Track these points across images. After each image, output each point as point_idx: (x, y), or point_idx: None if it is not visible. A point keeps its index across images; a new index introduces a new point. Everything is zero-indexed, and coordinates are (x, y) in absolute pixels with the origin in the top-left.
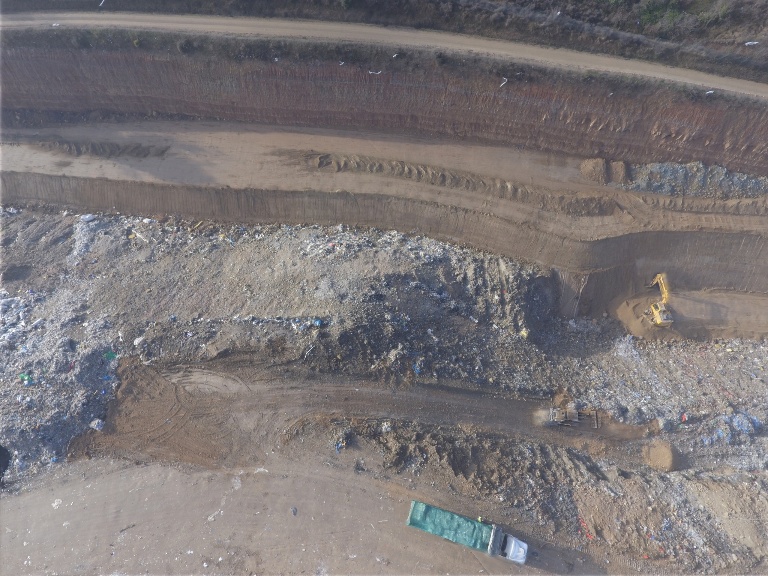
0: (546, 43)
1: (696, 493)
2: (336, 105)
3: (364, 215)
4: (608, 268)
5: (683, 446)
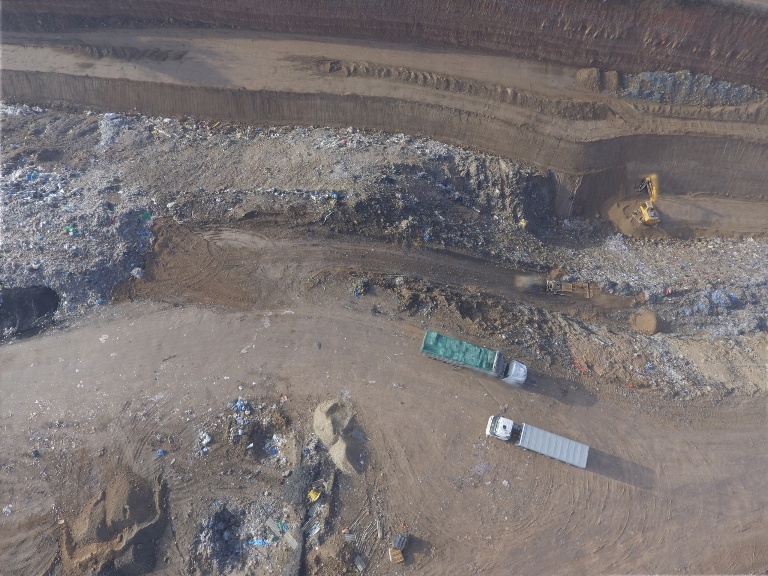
0: None
1: (677, 347)
2: (346, 12)
3: (373, 118)
4: (601, 170)
5: (666, 315)
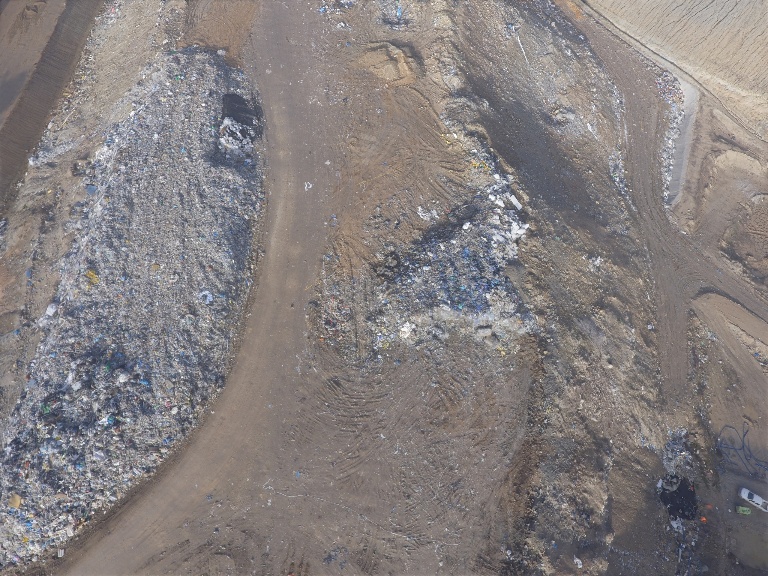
0: None
1: None
2: None
3: (91, 3)
4: None
5: None
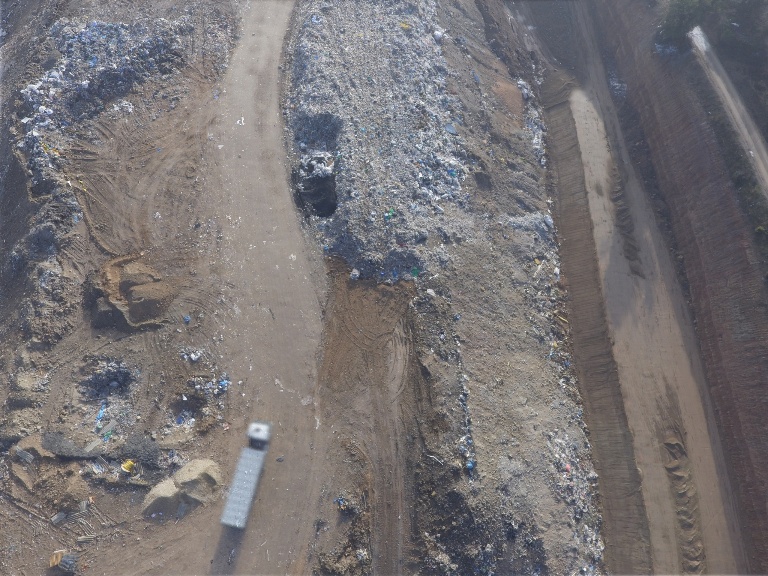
0: None
1: None
2: (761, 461)
3: (616, 505)
4: None
5: None
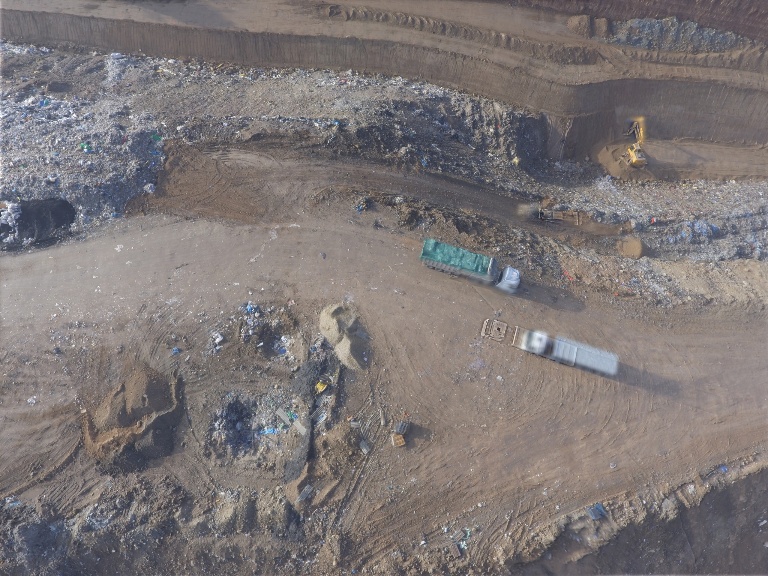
0: None
1: (660, 267)
2: None
3: (371, 62)
4: (590, 113)
5: (651, 243)
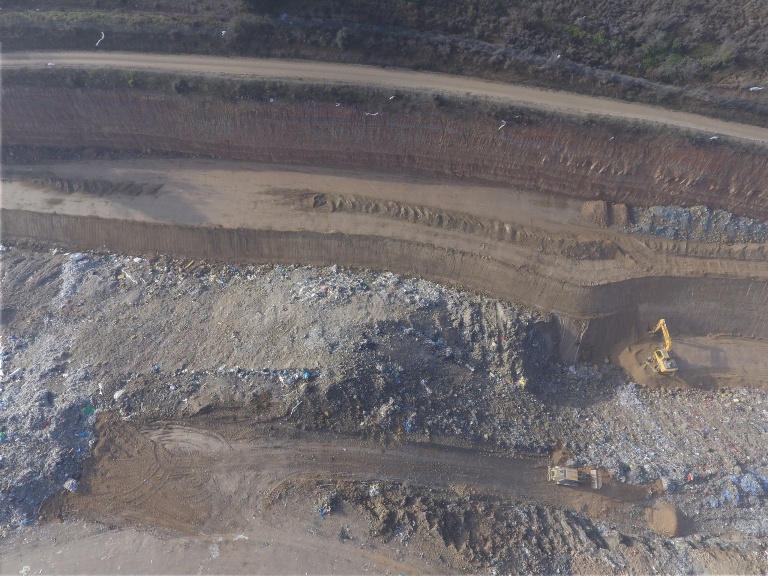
0: (546, 86)
1: (702, 564)
2: (332, 145)
3: (359, 256)
4: (610, 313)
5: (688, 509)
